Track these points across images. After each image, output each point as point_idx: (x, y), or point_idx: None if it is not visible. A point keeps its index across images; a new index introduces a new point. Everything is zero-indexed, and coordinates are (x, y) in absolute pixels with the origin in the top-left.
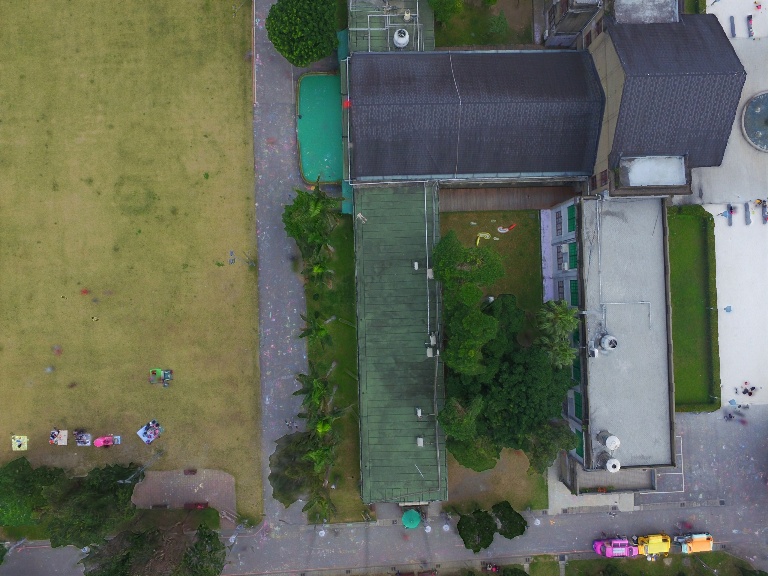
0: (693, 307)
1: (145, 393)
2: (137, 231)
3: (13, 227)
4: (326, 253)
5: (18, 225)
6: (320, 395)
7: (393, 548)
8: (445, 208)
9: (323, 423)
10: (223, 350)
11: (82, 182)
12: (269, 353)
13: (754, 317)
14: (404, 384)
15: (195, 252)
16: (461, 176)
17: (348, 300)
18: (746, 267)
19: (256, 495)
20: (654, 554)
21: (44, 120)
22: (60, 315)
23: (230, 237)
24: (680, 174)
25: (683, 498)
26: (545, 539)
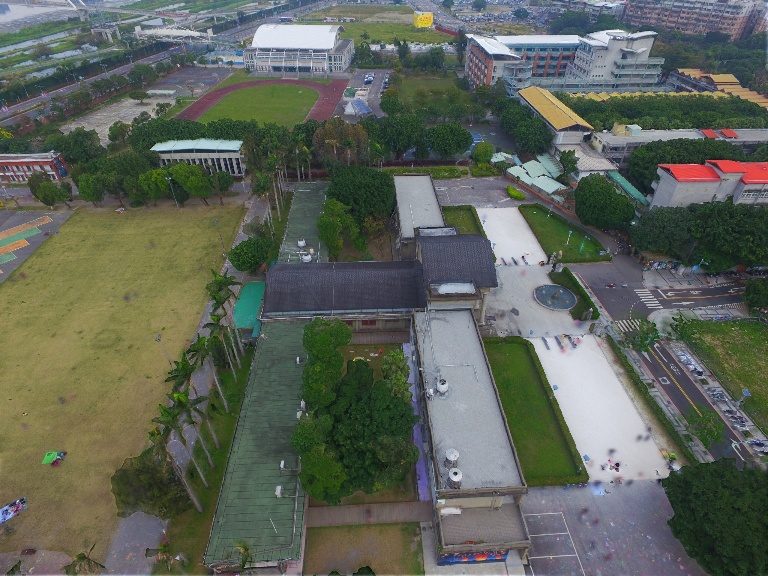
0: (537, 401)
1: (30, 473)
2: (96, 358)
3: (6, 357)
4: (223, 312)
5: (10, 356)
6: (186, 373)
7: None
8: None
9: None
10: (122, 437)
11: (74, 333)
12: None
13: (594, 408)
14: (273, 444)
15: (133, 370)
16: (336, 312)
17: None
18: (572, 374)
19: None
20: None
21: (70, 305)
22: None
23: (164, 361)
24: (472, 290)
25: None
26: None
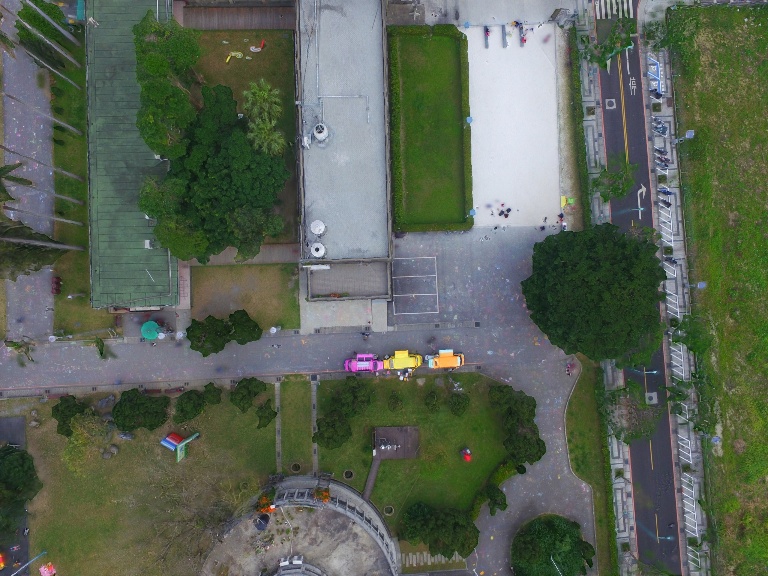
0: (449, 129)
1: None
2: None
3: None
4: None
5: None
6: None
7: (140, 365)
8: (196, 26)
9: None
10: None
11: None
12: None
13: (511, 140)
14: (135, 189)
15: None
16: None
17: None
18: (504, 90)
19: None
20: (406, 374)
21: None
22: None
23: None
24: None
25: (438, 319)
26: (296, 358)
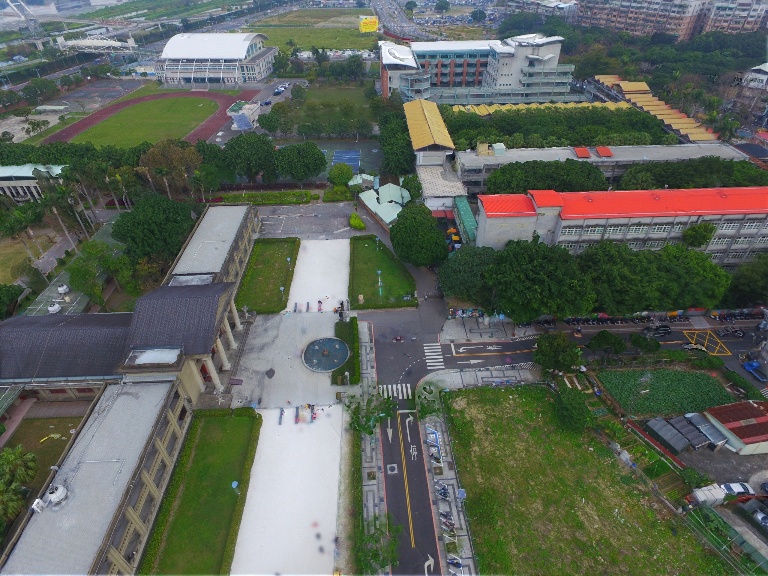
0: (226, 497)
1: None
2: None
3: None
4: None
5: None
6: None
7: None
8: (35, 415)
9: None
10: None
11: None
12: None
13: (289, 507)
14: None
15: None
16: (38, 380)
17: None
18: (289, 459)
19: None
20: None
21: None
22: None
23: None
24: None
25: None
26: None
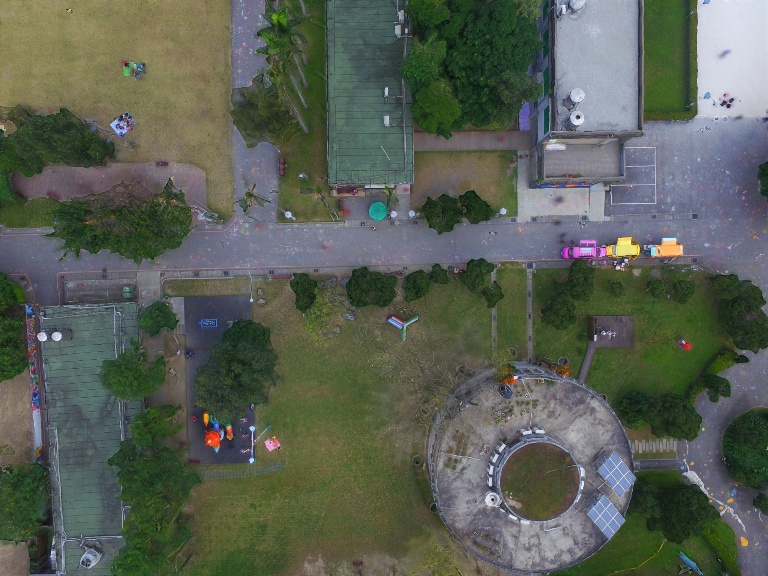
0: (672, 16)
1: (118, 85)
2: None
3: None
4: None
5: None
6: None
7: (361, 249)
8: None
9: (279, 15)
10: (195, 46)
11: None
12: (241, 51)
13: (736, 28)
14: (372, 66)
15: None
16: None
17: (320, 1)
18: None
19: (226, 191)
20: (623, 264)
21: None
22: (35, 6)
23: None
24: None
25: (655, 210)
26: (513, 246)
